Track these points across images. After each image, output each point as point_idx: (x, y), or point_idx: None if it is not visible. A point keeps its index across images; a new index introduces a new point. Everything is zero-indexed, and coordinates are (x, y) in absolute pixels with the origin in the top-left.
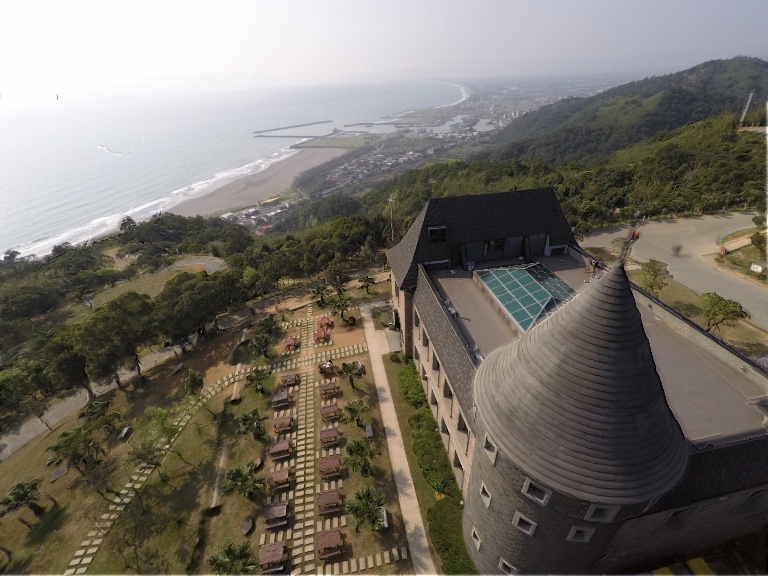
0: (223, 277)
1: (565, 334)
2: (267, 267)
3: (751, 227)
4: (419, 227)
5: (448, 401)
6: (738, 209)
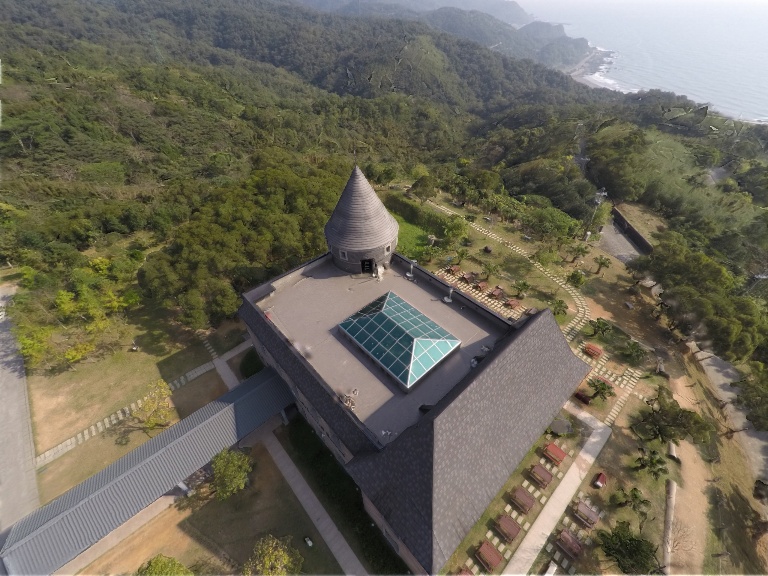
0: (721, 323)
1: None
2: (760, 387)
3: None
4: None
5: None
6: None
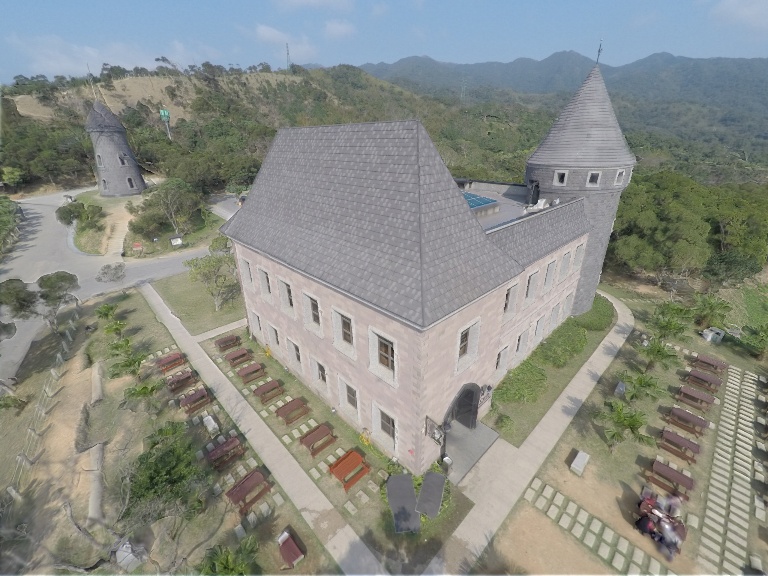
0: None
1: None
2: None
3: (72, 240)
4: (446, 180)
5: None
6: None
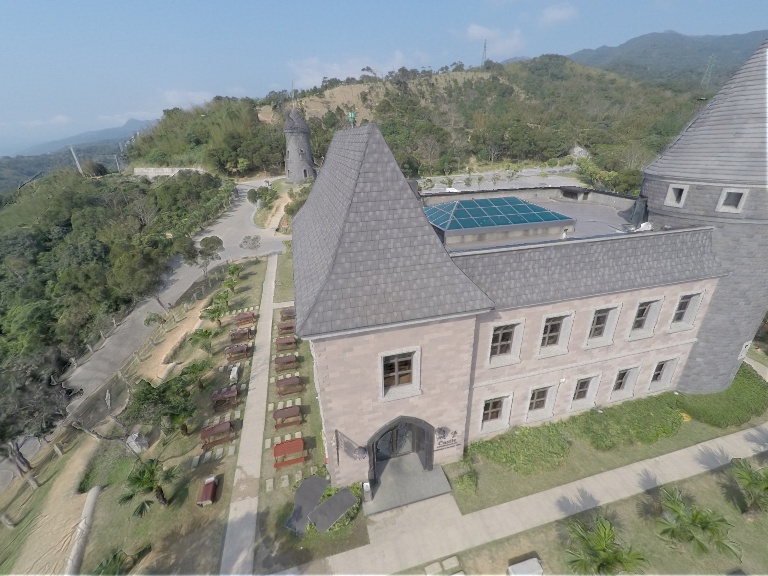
0: None
1: None
2: None
3: (254, 215)
4: (397, 188)
5: (634, 334)
6: (224, 210)
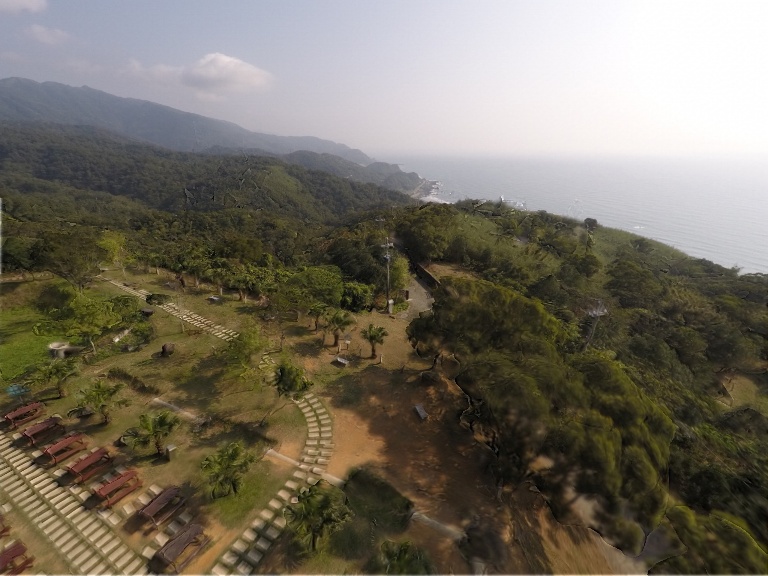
0: (572, 437)
1: None
2: None
3: None
4: None
5: None
6: None
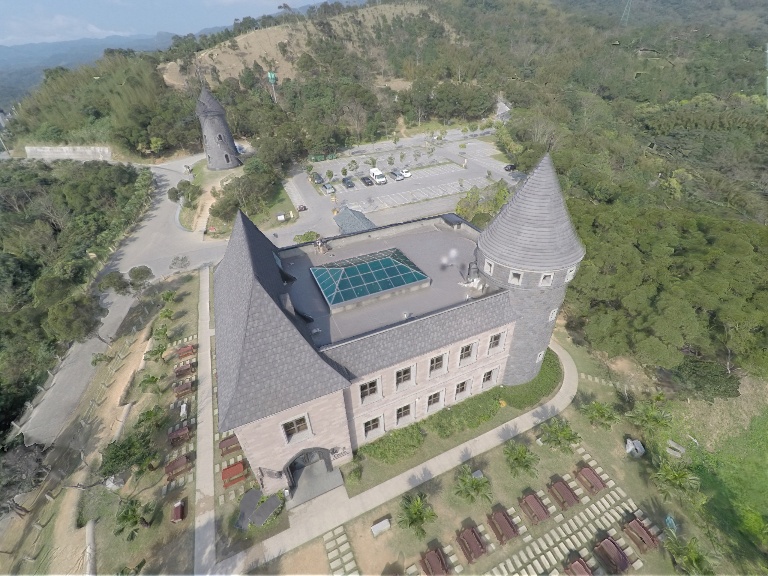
0: None
1: (558, 195)
2: None
3: (178, 213)
4: (277, 320)
5: (463, 362)
6: (146, 209)
